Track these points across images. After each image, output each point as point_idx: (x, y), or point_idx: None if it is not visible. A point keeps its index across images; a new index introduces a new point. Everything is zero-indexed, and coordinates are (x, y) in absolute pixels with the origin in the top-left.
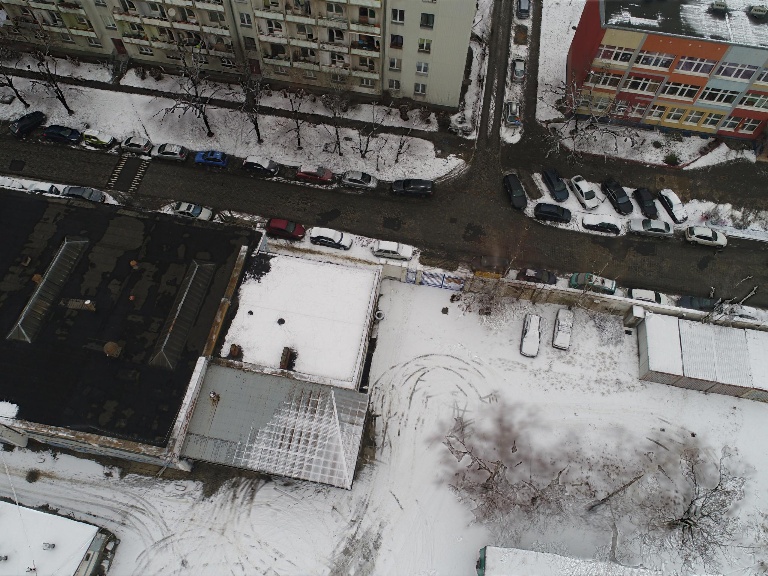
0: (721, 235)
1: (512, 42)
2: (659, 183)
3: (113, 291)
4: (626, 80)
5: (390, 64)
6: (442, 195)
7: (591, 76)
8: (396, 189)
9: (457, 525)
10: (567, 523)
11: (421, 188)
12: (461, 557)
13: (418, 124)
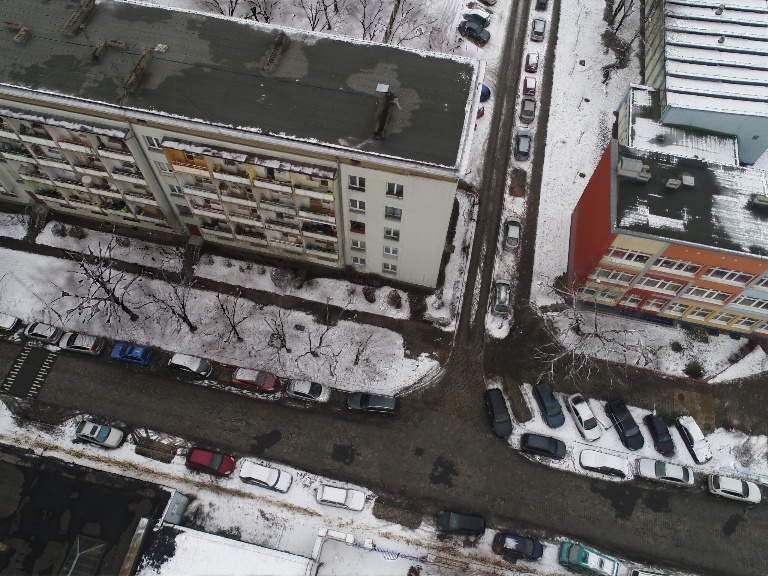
0: (753, 488)
1: (507, 193)
2: (677, 402)
3: None
4: (641, 278)
5: (352, 243)
6: (408, 413)
7: (598, 270)
8: (351, 406)
9: None
10: None
11: (382, 408)
12: None
13: (386, 308)
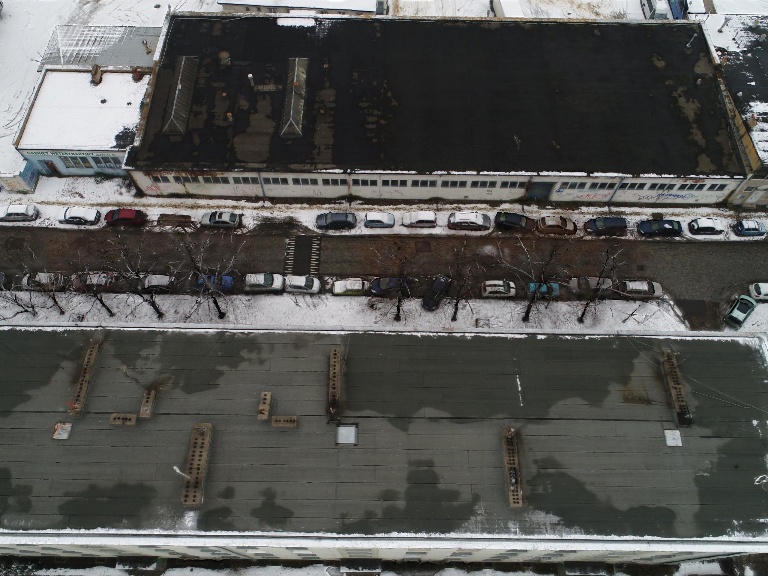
0: None
1: None
2: None
3: (244, 101)
4: None
5: None
6: None
7: None
8: (0, 274)
9: (2, 49)
10: None
11: None
12: (4, 37)
13: None
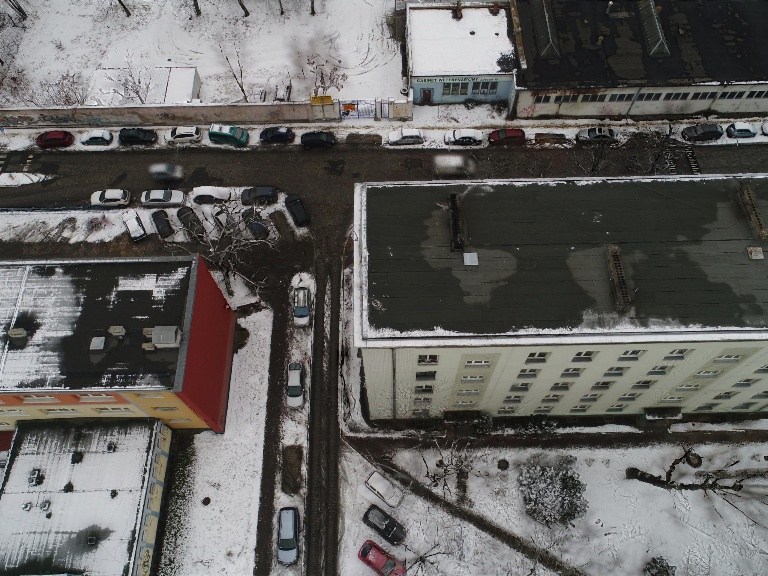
0: (95, 199)
1: (305, 449)
2: (141, 253)
3: (604, 27)
4: None
5: None
6: None
7: None
8: None
9: None
10: (262, 6)
11: None
12: None
13: None
